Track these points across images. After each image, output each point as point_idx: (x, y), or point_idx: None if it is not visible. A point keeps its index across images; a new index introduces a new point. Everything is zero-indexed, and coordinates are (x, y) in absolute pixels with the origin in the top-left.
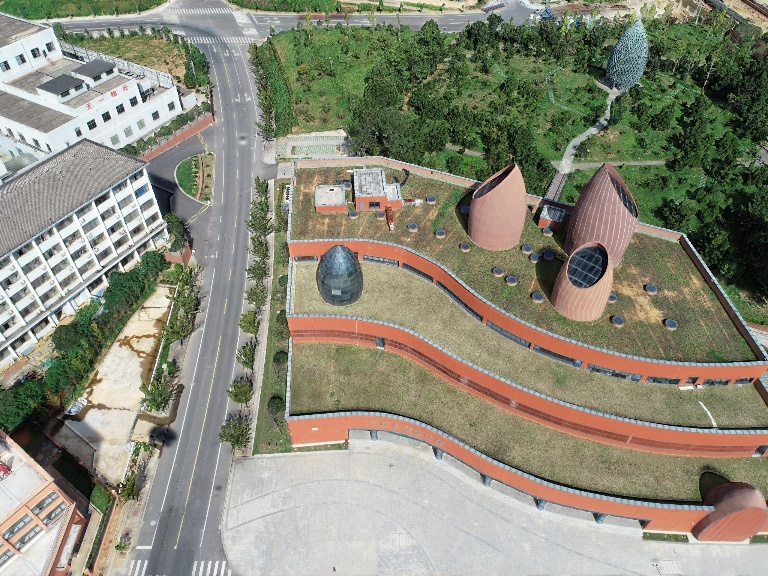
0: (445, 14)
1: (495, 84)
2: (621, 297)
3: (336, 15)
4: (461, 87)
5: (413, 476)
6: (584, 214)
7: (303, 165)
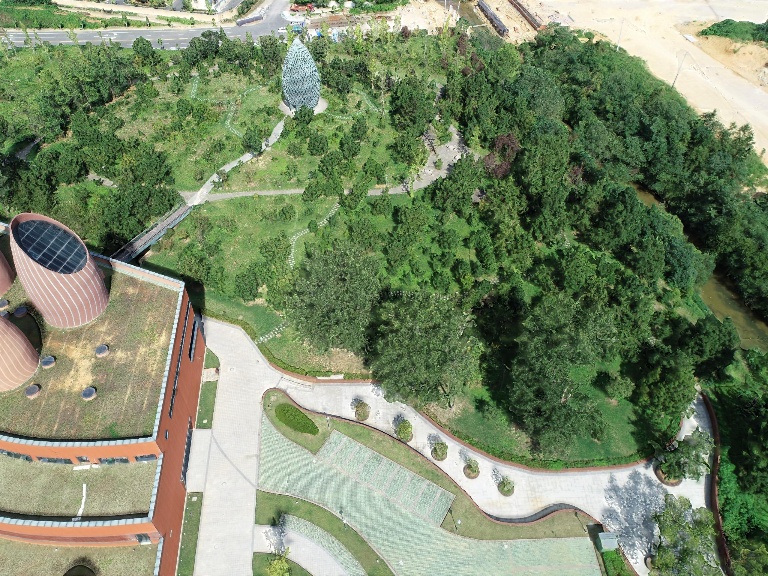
0: (195, 28)
1: None
2: (63, 361)
3: (79, 31)
4: (140, 110)
5: None
6: None
7: None
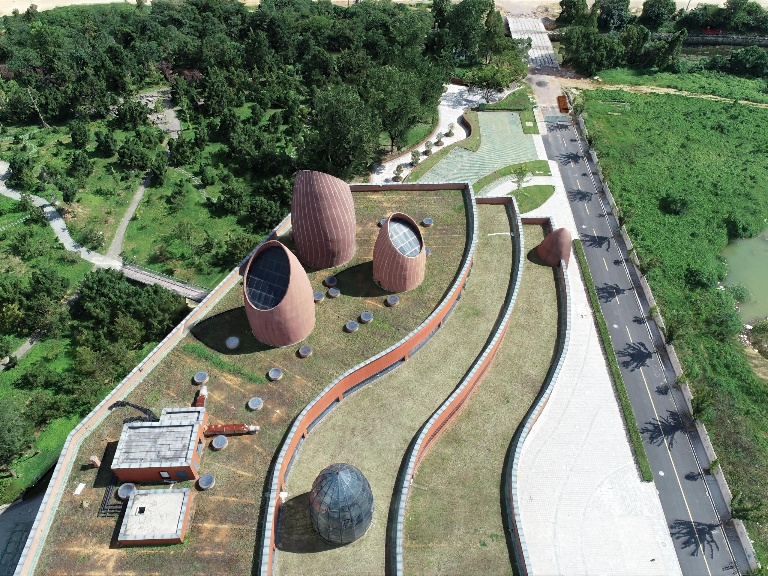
0: None
1: None
2: None
3: None
4: None
5: (540, 477)
6: (332, 221)
7: (24, 575)
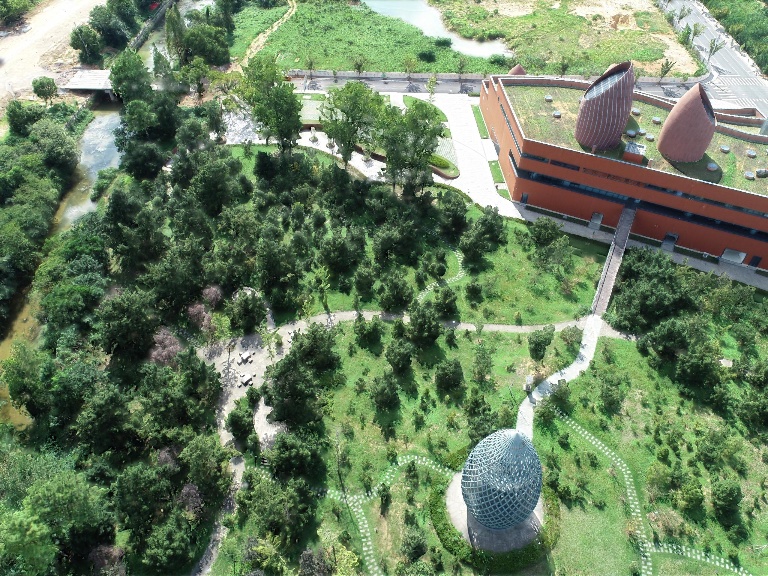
0: None
1: (760, 545)
2: None
3: None
4: None
5: None
6: None
7: None
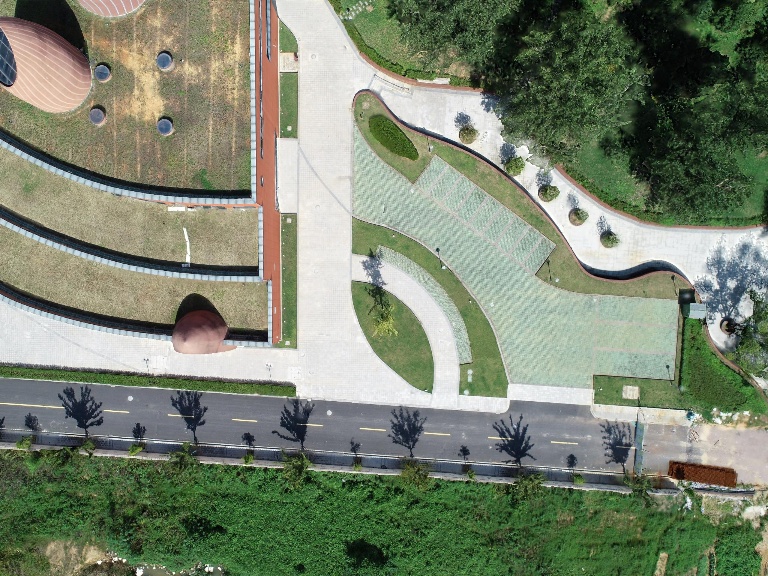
0: None
1: None
2: (120, 72)
3: None
4: None
5: None
6: None
7: None
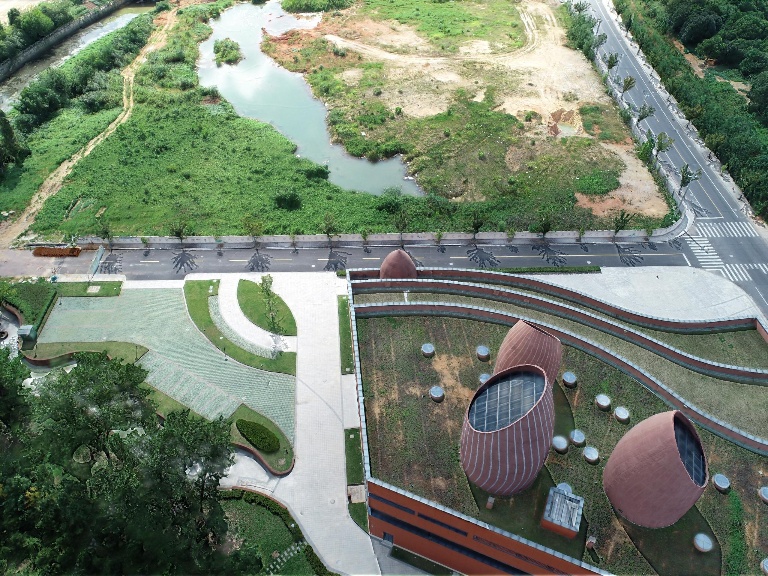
0: None
1: None
2: (473, 384)
3: None
4: None
5: None
6: None
7: None
